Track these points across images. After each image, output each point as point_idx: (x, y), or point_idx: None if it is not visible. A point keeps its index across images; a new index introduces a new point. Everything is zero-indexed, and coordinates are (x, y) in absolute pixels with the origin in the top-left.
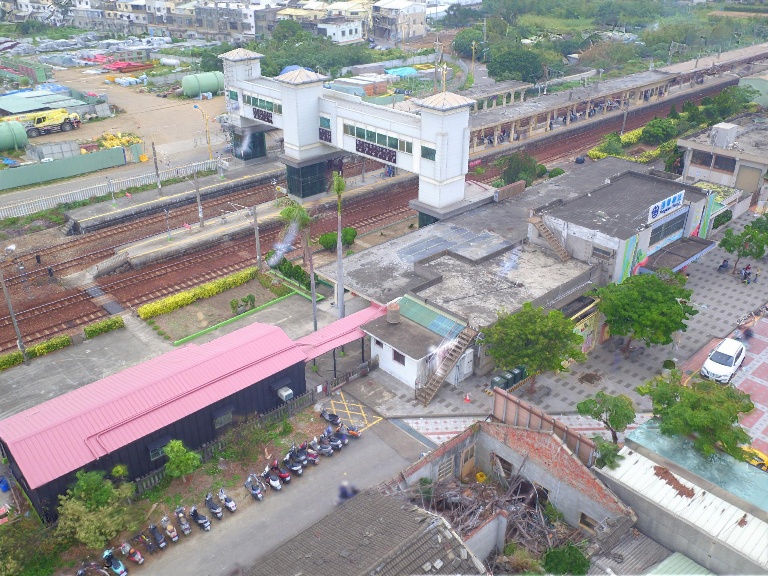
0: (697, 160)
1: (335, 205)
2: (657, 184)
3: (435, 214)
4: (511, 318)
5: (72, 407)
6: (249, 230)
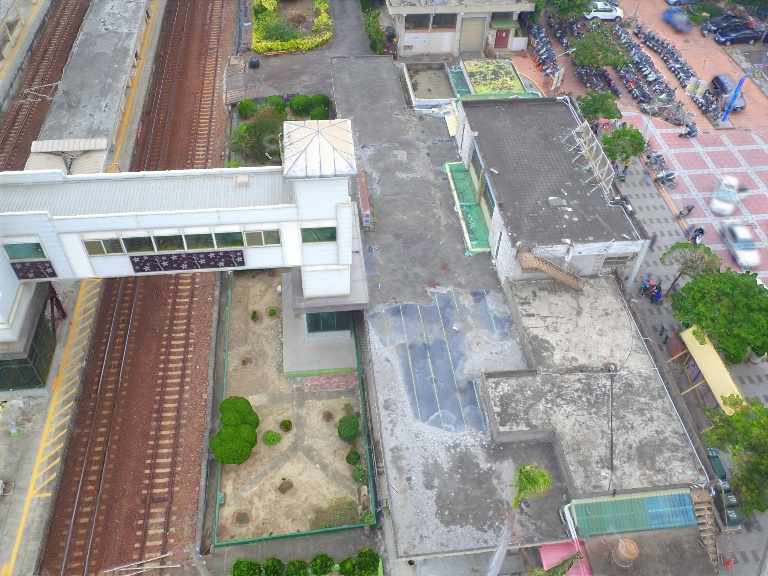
0: (409, 24)
1: (88, 351)
2: (506, 109)
3: (353, 307)
4: None
5: None
6: (46, 526)
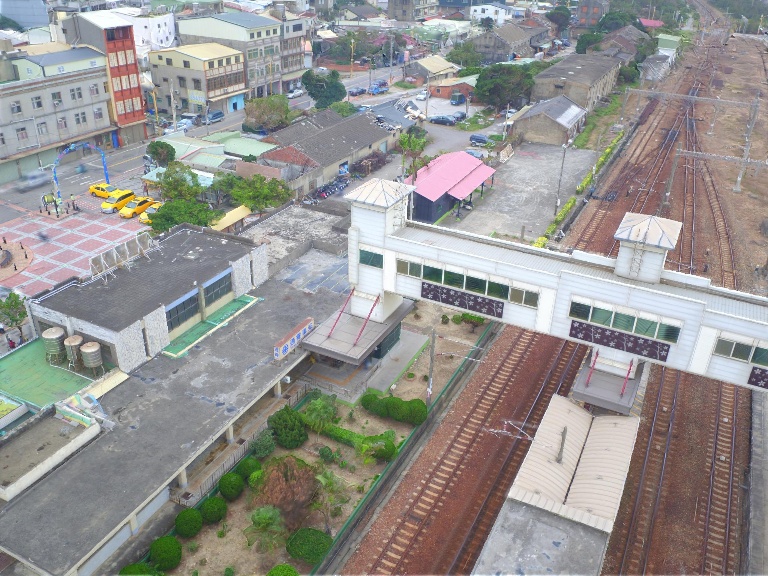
0: None
1: None
2: (89, 320)
3: None
4: (276, 191)
5: (462, 163)
6: None
